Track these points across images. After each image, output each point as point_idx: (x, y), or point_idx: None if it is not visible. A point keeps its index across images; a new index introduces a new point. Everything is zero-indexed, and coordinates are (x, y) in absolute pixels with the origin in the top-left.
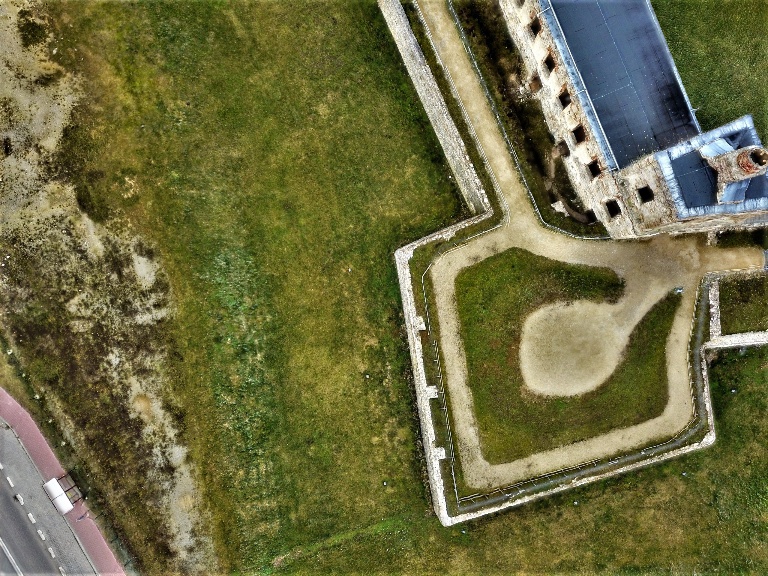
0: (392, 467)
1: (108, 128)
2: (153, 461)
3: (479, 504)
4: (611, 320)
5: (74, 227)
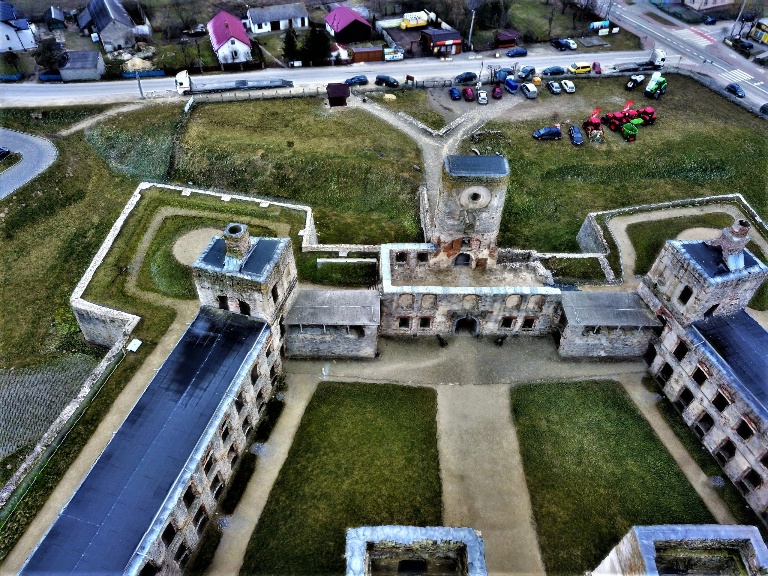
0: None
1: None
2: None
3: (724, 199)
4: None
5: None
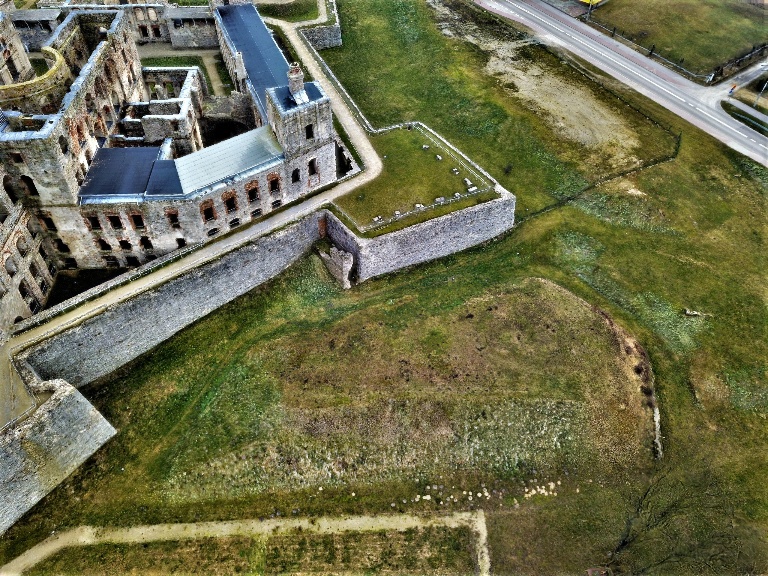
0: (348, 6)
1: (468, 61)
2: (438, 0)
3: None
4: (260, 0)
5: (479, 41)
